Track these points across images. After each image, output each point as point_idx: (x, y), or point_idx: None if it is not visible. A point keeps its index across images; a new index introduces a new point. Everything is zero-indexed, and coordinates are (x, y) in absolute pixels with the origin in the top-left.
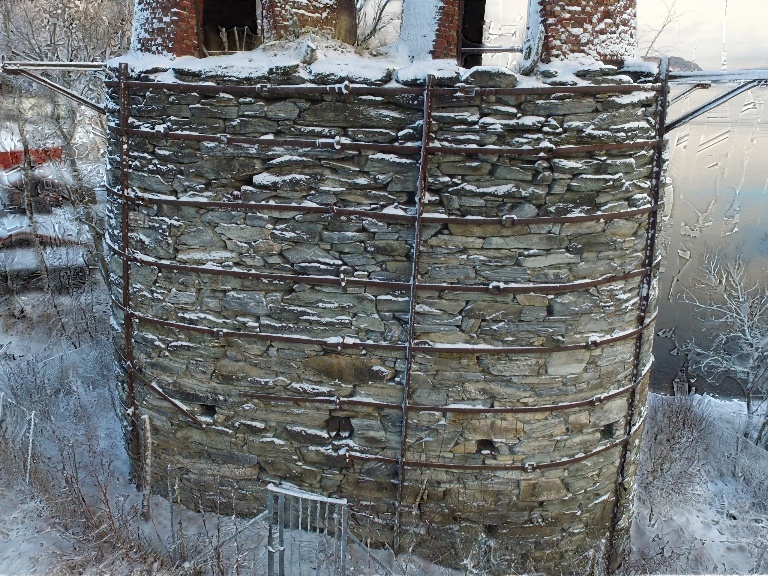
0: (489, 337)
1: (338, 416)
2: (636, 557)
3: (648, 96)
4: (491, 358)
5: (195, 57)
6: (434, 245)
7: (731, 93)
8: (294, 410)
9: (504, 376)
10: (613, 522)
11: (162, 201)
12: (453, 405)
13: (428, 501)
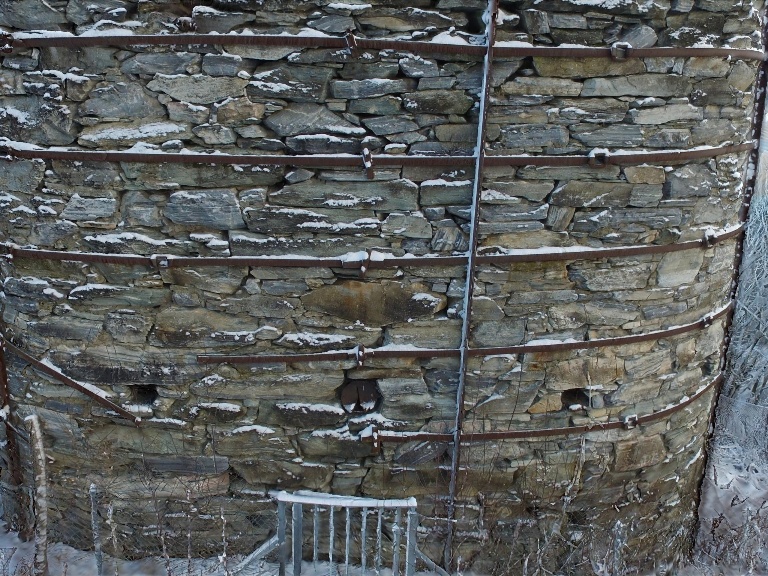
0: (585, 235)
1: (359, 378)
2: (703, 529)
3: None
4: (587, 266)
5: None
6: (511, 93)
7: None
8: (288, 377)
9: (604, 292)
10: (699, 487)
11: (48, 41)
12: (534, 341)
13: (493, 490)
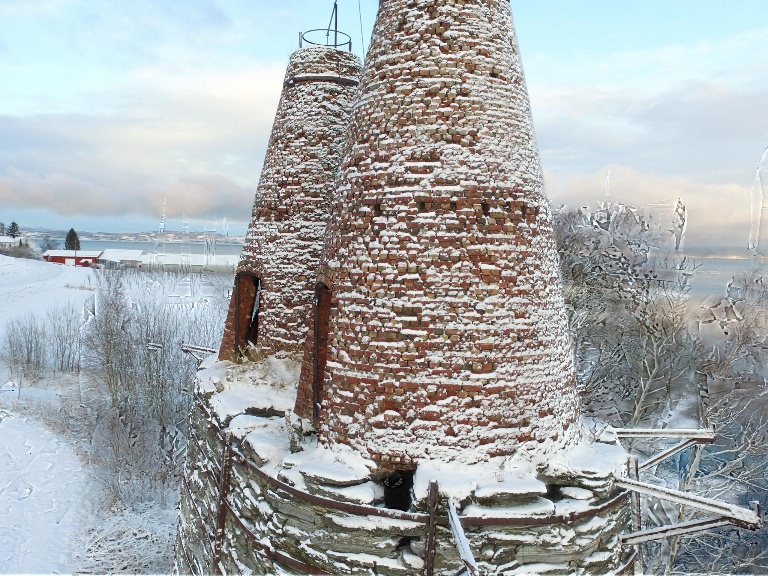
0: None
1: None
2: None
3: (400, 526)
4: None
5: (232, 362)
6: None
7: (462, 572)
8: None
9: None
10: None
11: None
12: None
13: None
